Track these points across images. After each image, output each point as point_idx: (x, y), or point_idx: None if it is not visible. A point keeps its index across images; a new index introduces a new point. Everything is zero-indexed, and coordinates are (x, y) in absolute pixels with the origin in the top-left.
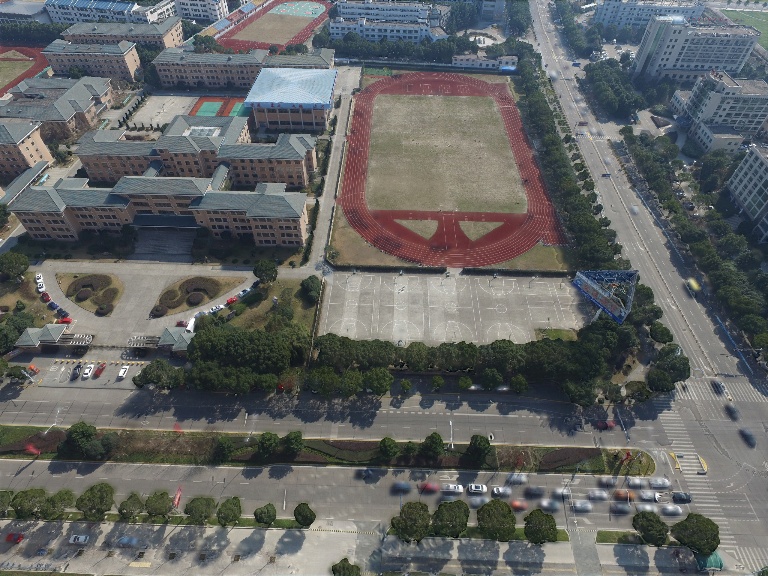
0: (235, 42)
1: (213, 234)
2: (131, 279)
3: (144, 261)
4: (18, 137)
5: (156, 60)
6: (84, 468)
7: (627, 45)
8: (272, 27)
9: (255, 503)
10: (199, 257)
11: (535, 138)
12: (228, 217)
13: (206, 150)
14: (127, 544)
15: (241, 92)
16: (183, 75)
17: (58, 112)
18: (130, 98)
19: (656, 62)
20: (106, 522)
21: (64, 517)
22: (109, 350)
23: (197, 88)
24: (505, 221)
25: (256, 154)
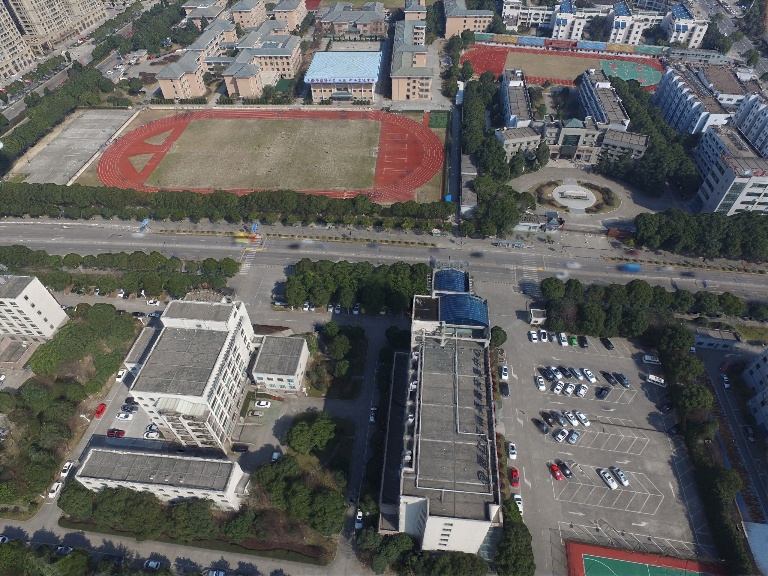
0: (500, 54)
1: None
2: None
3: None
4: (278, 8)
5: None
6: None
7: (649, 405)
8: (551, 64)
9: (21, 103)
10: None
11: None
12: None
13: None
14: None
15: (387, 67)
16: None
17: (327, 16)
18: None
19: None
20: None
21: None
22: None
23: None
24: (140, 173)
25: None
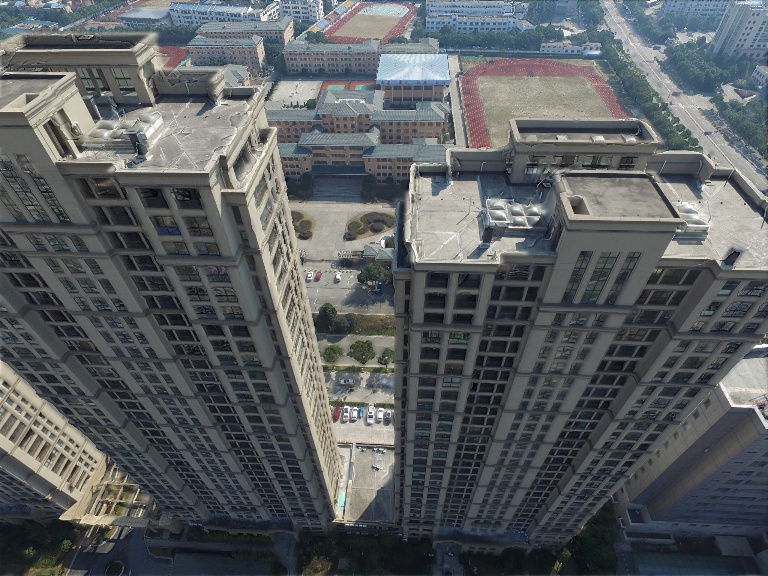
0: (337, 38)
1: (376, 181)
2: (318, 214)
3: (324, 202)
4: None
5: (286, 50)
6: (332, 338)
7: (697, 33)
8: (366, 25)
9: None
10: (369, 198)
11: (632, 108)
12: (394, 165)
13: (362, 114)
14: (385, 385)
15: (358, 77)
16: (307, 63)
17: None
18: (263, 83)
19: (734, 43)
20: (364, 372)
21: (330, 368)
22: (320, 262)
23: (319, 74)
24: None
25: (404, 117)
